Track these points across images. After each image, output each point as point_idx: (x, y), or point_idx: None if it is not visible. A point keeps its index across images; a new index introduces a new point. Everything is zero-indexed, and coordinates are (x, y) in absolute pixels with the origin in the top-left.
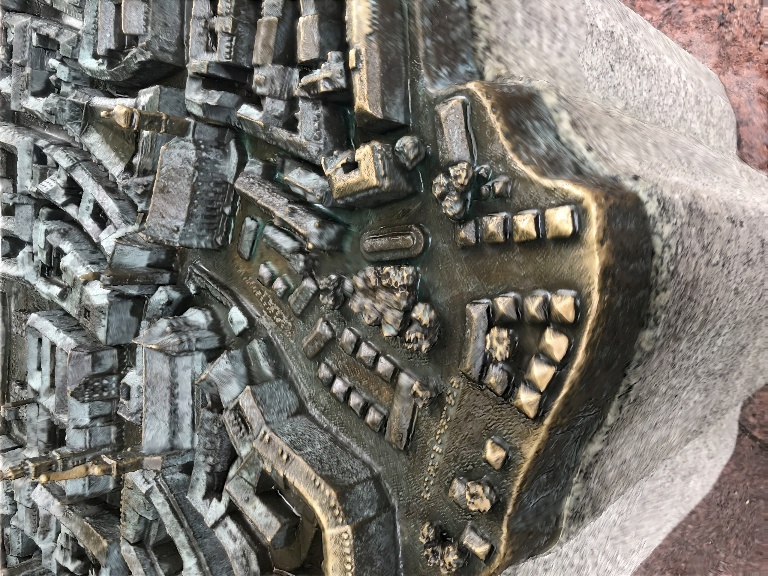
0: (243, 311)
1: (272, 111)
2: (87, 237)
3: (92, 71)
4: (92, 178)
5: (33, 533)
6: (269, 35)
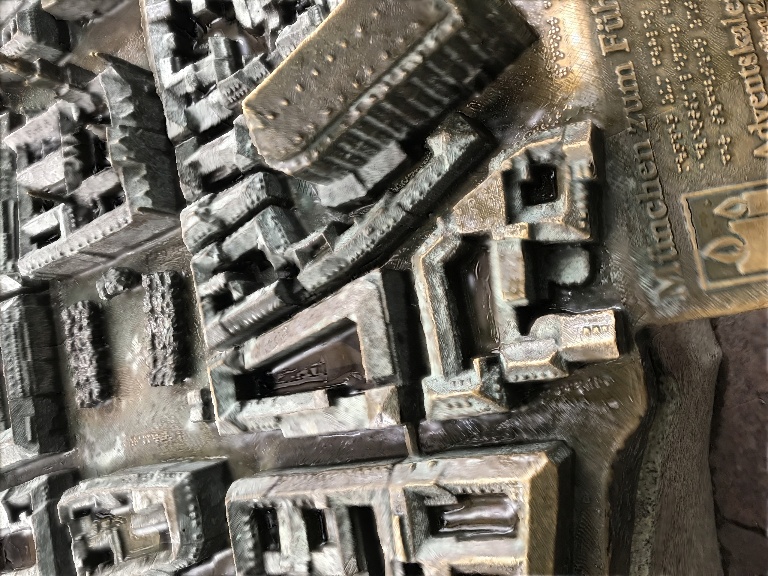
0: None
1: None
2: None
3: None
4: None
5: None
6: None
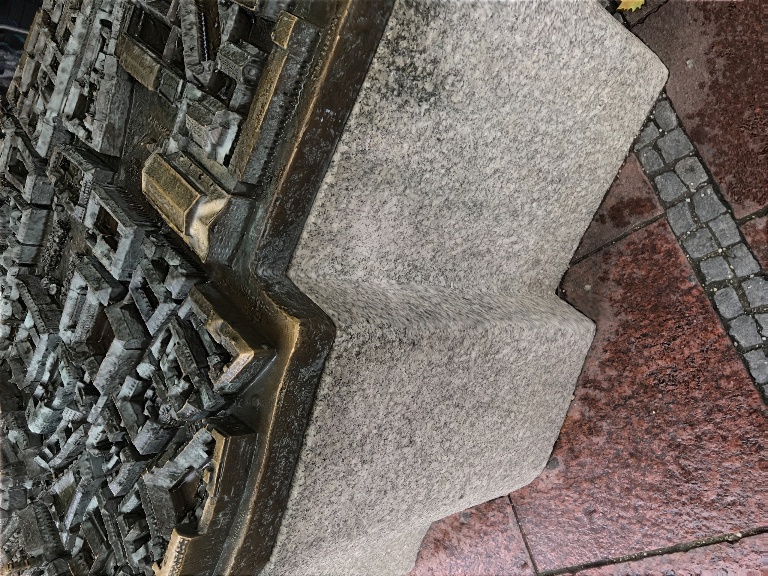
0: None
1: None
2: None
3: None
4: None
5: None
6: None
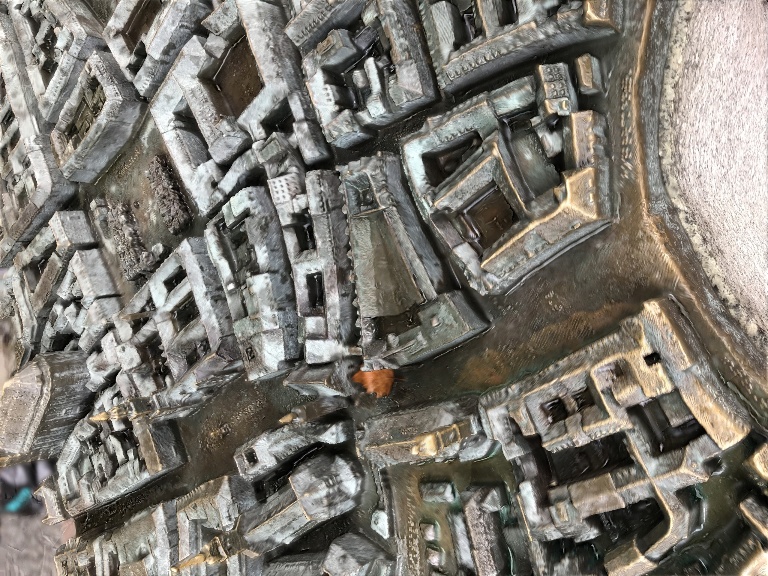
0: (390, 524)
1: (547, 533)
2: (283, 239)
3: (412, 182)
4: (332, 251)
5: (86, 349)
6: (605, 504)
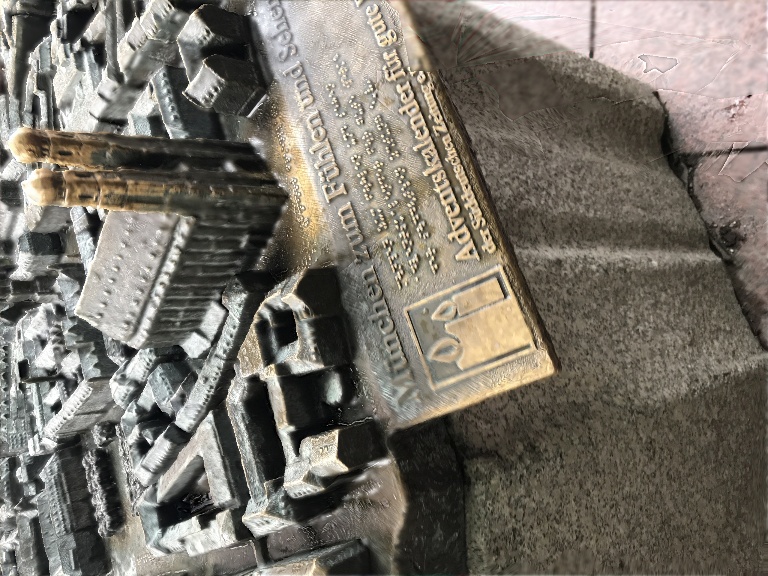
0: None
1: None
2: None
3: None
4: None
5: None
6: None
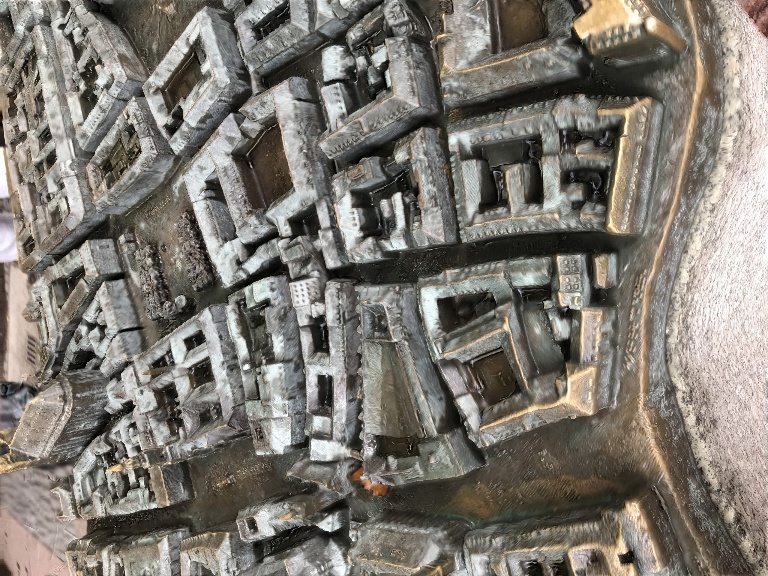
0: None
1: None
2: None
3: (425, 324)
4: (344, 360)
5: (107, 374)
6: None
